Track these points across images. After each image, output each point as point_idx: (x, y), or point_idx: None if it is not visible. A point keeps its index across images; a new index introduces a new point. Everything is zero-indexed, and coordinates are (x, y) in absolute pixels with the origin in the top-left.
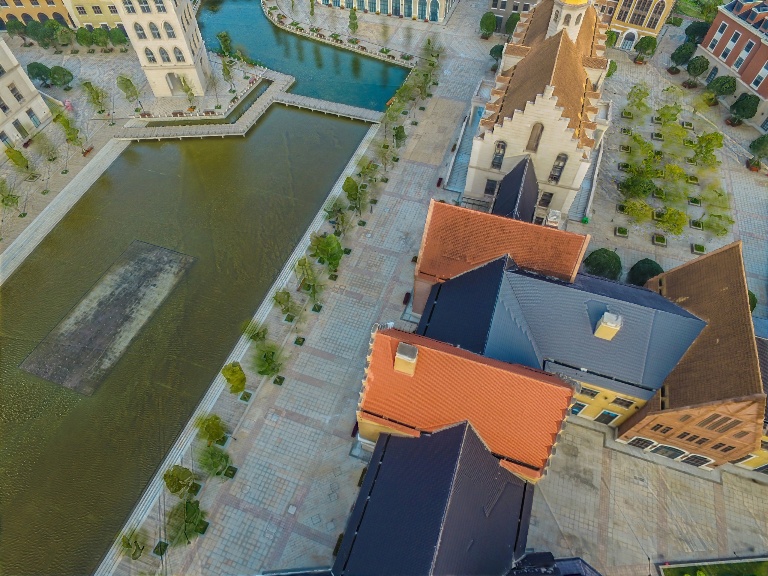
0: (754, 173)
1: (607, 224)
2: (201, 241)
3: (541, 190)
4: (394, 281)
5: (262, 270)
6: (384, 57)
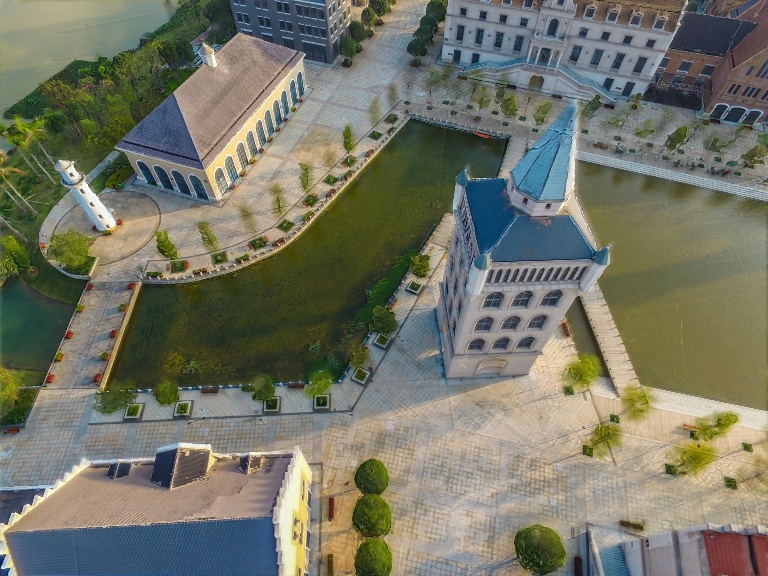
0: None
1: None
2: (762, 264)
3: None
4: (733, 134)
5: (767, 214)
6: (390, 136)
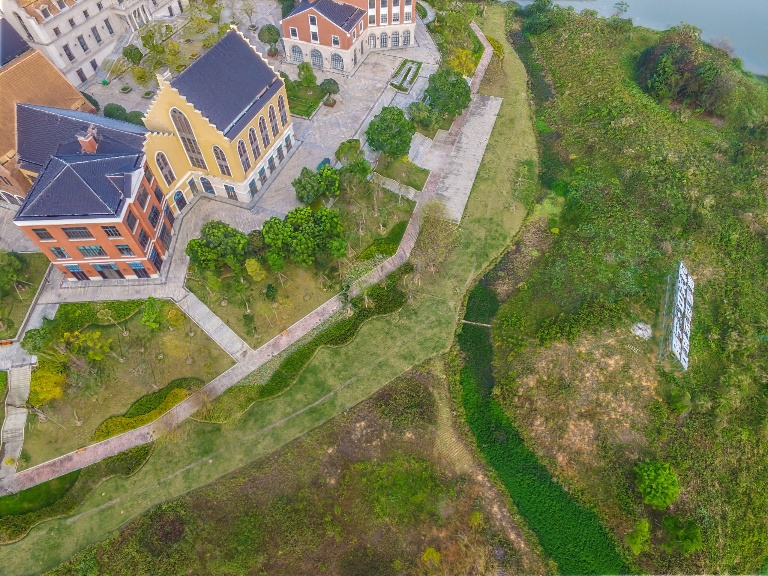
0: (270, 58)
1: (121, 86)
2: None
3: (32, 48)
4: None
5: None
6: None
